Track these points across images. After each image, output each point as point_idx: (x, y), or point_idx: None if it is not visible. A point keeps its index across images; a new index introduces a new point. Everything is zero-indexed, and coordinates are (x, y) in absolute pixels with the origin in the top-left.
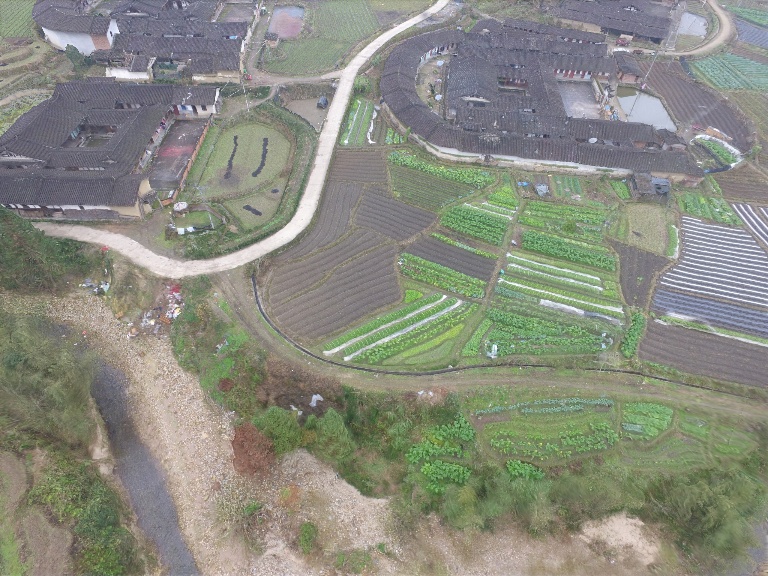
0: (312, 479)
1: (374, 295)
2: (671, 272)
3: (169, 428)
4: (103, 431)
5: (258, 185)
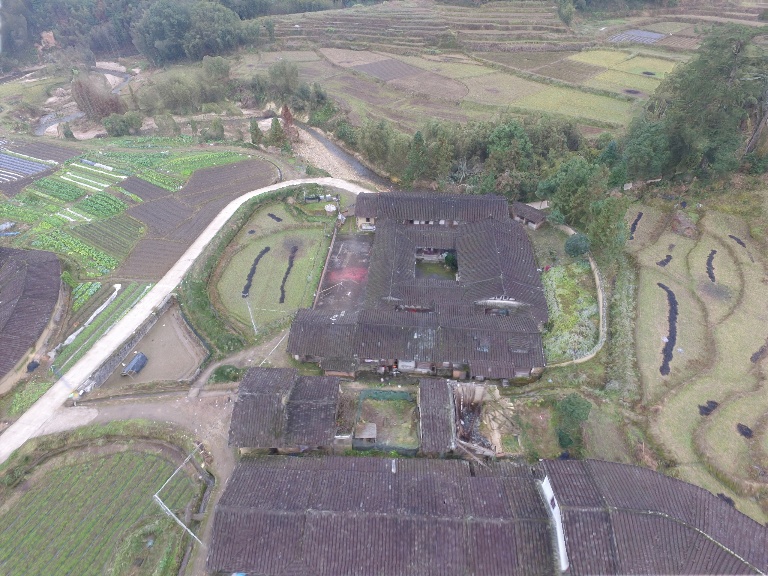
0: (271, 147)
1: (210, 173)
2: (5, 181)
3: (332, 161)
4: (361, 161)
5: (265, 231)
